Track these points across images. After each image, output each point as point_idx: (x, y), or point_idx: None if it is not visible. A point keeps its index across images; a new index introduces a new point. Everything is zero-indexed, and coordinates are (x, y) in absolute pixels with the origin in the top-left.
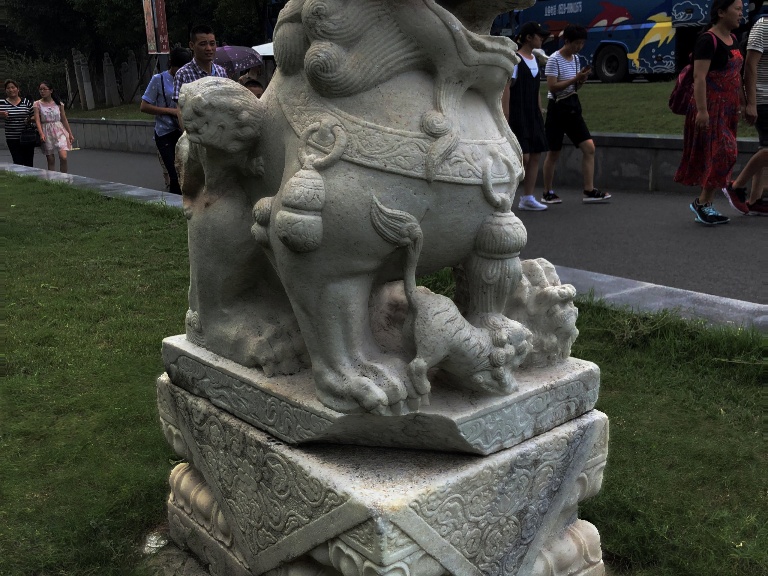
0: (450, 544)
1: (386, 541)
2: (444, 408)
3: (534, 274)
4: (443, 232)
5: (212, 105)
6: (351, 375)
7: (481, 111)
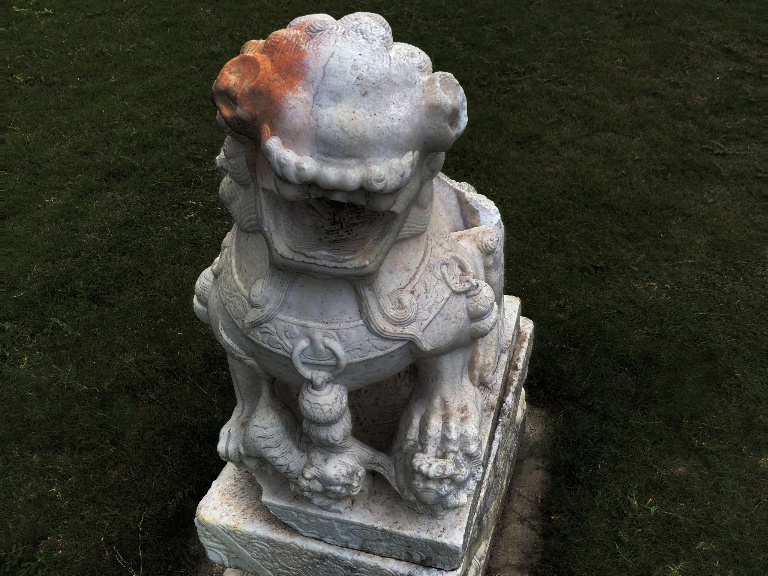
0: (262, 566)
1: (202, 533)
2: (274, 485)
3: (422, 434)
4: (272, 373)
5: (224, 168)
6: (232, 418)
7: (332, 291)
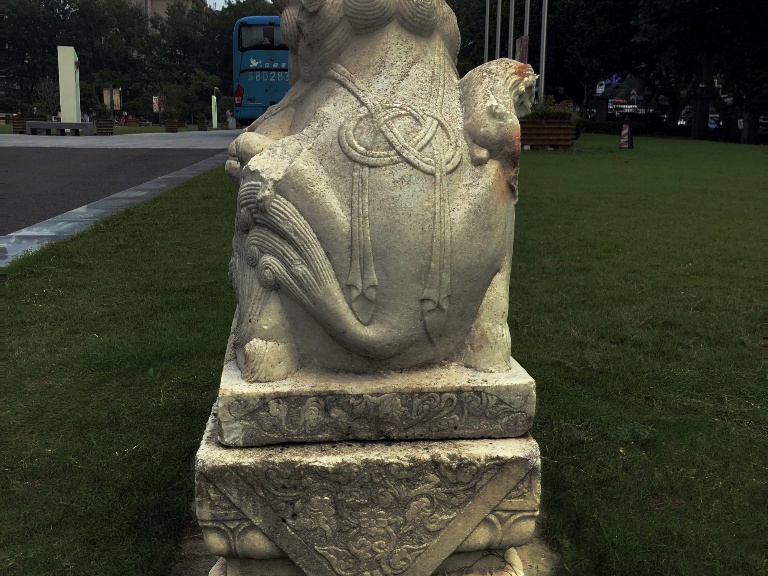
0: None
1: None
2: None
3: None
4: None
5: None
6: None
7: None
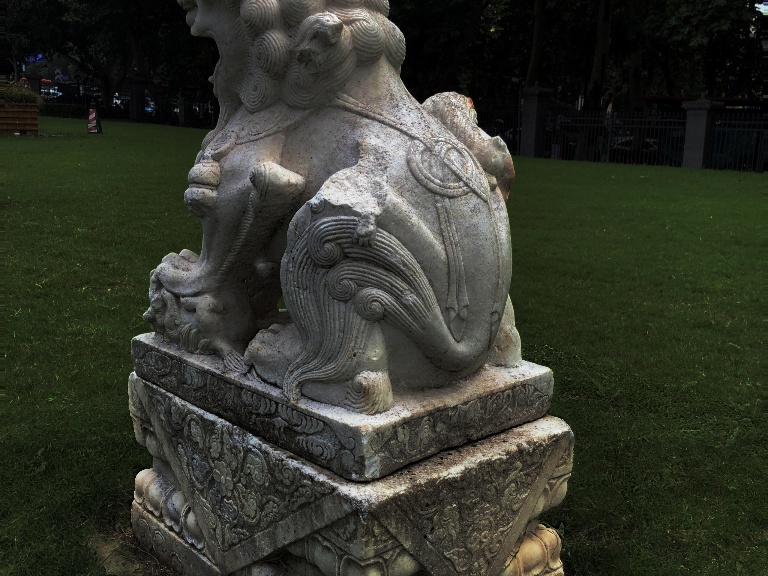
0: None
1: None
2: None
3: None
4: None
5: None
6: None
7: None
